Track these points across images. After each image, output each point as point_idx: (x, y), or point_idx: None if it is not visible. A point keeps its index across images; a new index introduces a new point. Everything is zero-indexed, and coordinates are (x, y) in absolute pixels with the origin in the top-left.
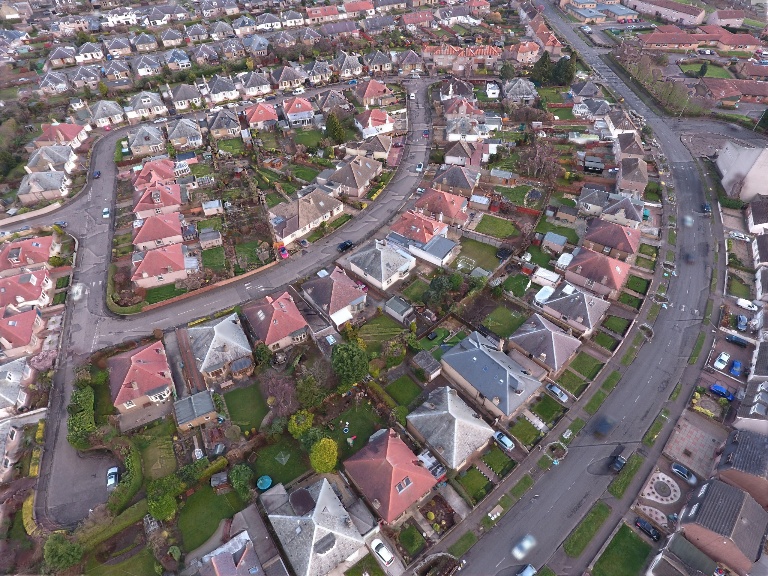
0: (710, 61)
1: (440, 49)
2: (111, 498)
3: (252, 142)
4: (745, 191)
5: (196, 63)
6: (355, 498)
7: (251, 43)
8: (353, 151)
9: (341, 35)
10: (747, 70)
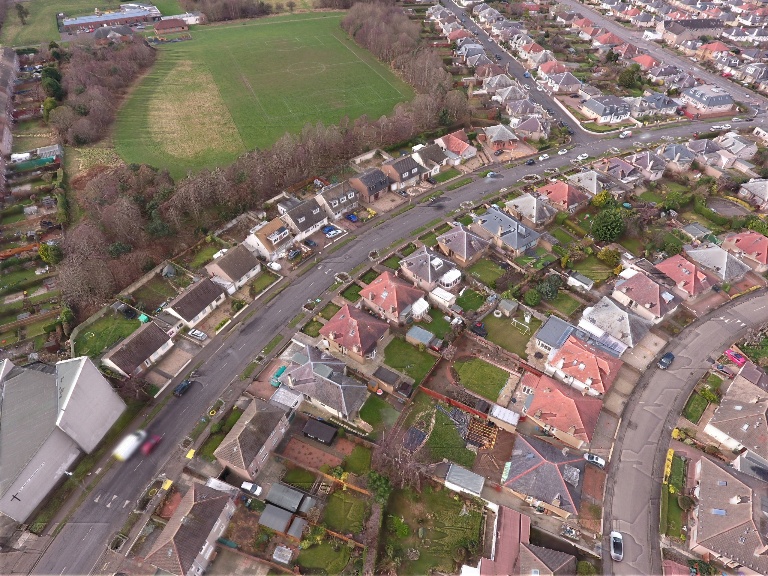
0: None
1: None
2: (703, 195)
3: None
4: None
5: None
6: None
7: None
8: None
9: None
10: None
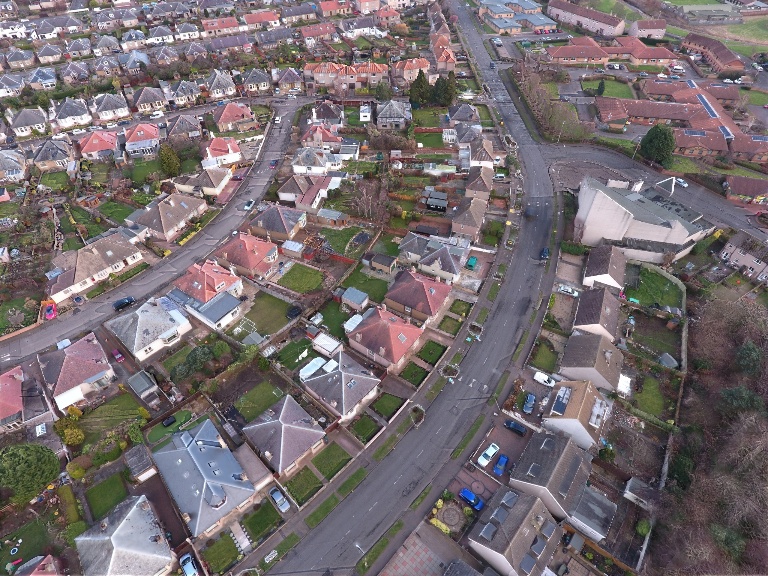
0: (615, 77)
1: (320, 67)
2: None
3: (76, 176)
4: (589, 235)
5: (61, 83)
6: None
7: (127, 60)
8: (181, 186)
9: (231, 50)
10: (647, 88)
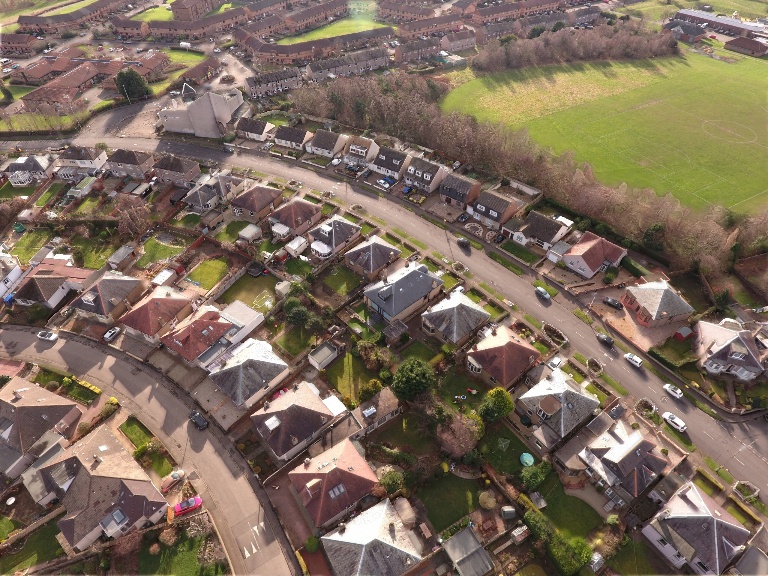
0: None
1: None
2: None
3: None
4: None
5: None
6: (521, 385)
7: None
8: None
9: None
10: (33, 75)
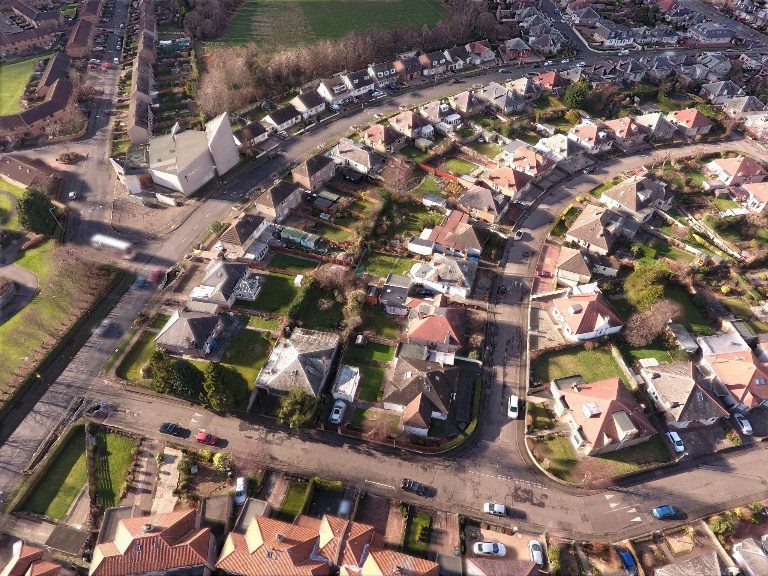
0: None
1: (417, 573)
2: None
3: (767, 302)
4: None
5: None
6: None
7: None
8: None
9: None
10: None
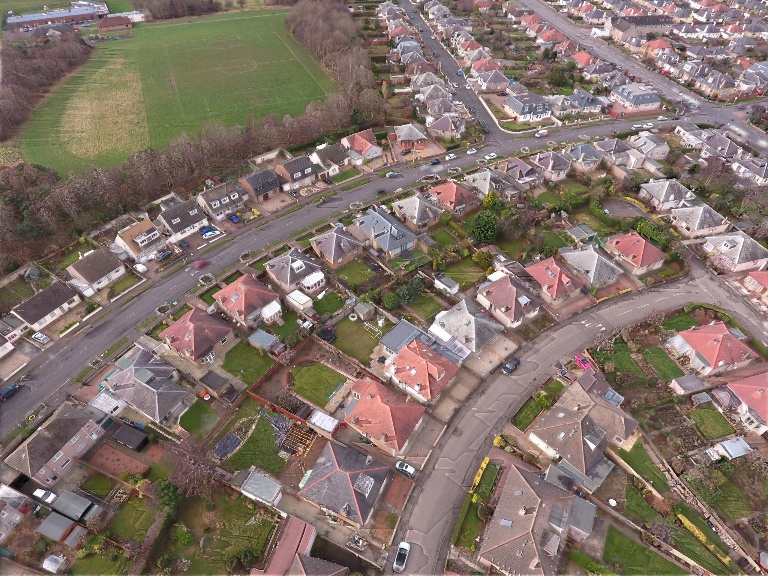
0: None
1: None
2: (597, 196)
3: None
4: None
5: None
6: None
7: None
8: None
9: None
10: None
